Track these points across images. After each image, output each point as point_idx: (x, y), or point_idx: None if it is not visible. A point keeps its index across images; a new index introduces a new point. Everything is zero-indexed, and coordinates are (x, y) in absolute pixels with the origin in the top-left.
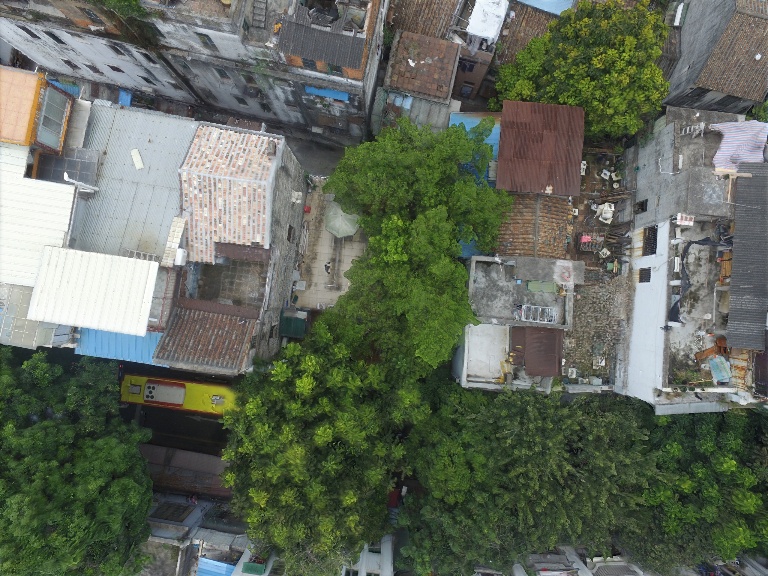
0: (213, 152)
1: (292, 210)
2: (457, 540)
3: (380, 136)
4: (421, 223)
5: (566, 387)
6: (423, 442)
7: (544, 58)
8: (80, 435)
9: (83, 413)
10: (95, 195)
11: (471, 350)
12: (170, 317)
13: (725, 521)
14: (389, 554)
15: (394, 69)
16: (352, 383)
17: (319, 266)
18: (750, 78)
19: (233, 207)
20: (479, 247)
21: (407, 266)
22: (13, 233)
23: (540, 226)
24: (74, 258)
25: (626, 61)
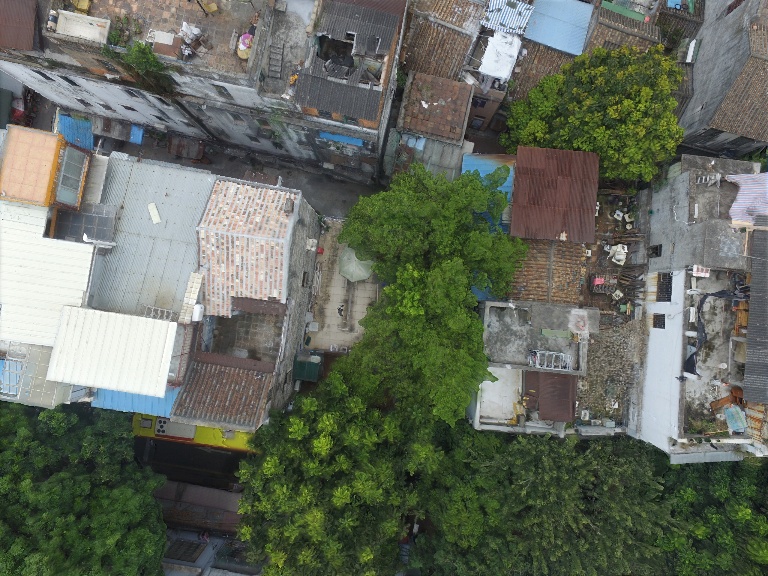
0: (230, 208)
1: (306, 256)
2: None
3: (394, 181)
4: (437, 276)
5: (579, 429)
6: (435, 483)
7: (558, 101)
8: (95, 484)
9: (98, 461)
10: (112, 250)
11: (484, 391)
12: (187, 372)
13: (740, 571)
14: None
15: (407, 111)
16: (369, 439)
17: (332, 307)
18: (764, 121)
19: (250, 263)
20: (493, 293)
21: (423, 318)
22: (32, 293)
23: (554, 271)
24: (93, 318)
25: (642, 112)
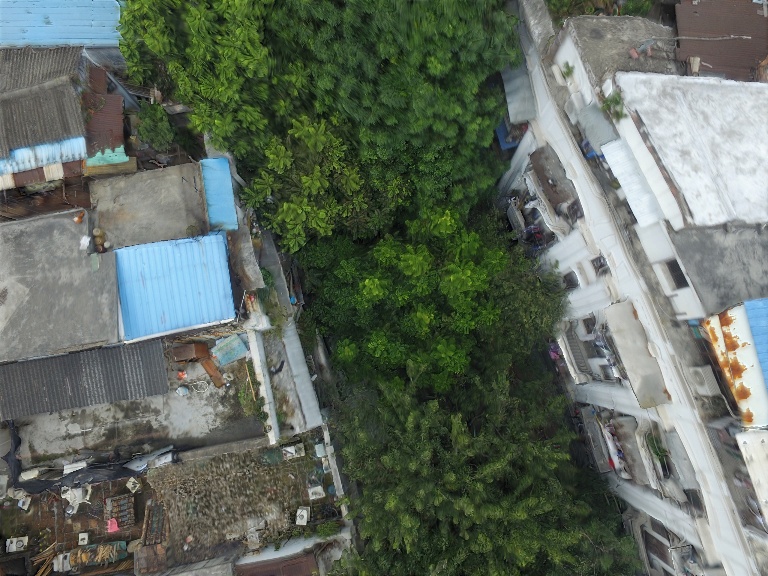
0: None
1: None
2: None
3: None
4: None
5: None
6: None
7: None
8: None
9: None
10: None
11: None
12: None
13: None
14: None
15: None
16: None
17: None
18: None
19: None
20: None
21: None
22: None
23: None
24: None
25: None
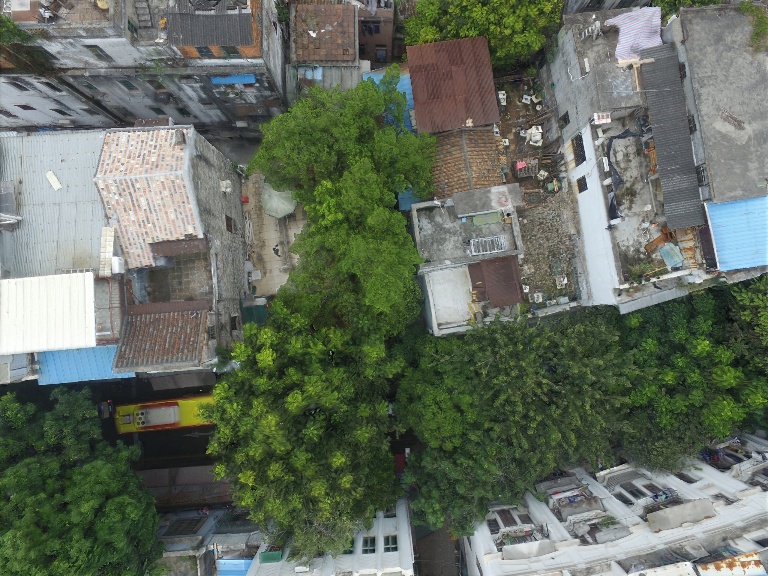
0: (125, 155)
1: (225, 200)
2: (461, 482)
3: None
4: (347, 179)
5: (535, 312)
6: (412, 399)
7: None
8: (66, 466)
9: (65, 445)
10: (19, 225)
11: (437, 299)
12: (122, 326)
13: (710, 400)
14: (404, 515)
15: (297, 44)
16: (314, 348)
17: (269, 252)
18: None
19: (157, 204)
20: (416, 194)
21: (345, 225)
22: None
23: (471, 161)
24: (8, 287)
25: None
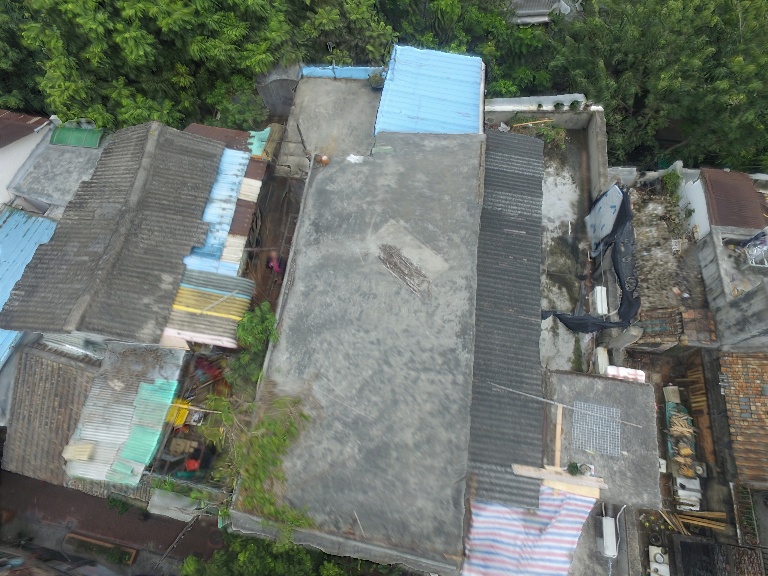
0: None
1: None
2: None
3: None
4: None
5: (639, 177)
6: None
7: None
8: None
9: None
10: None
11: None
12: None
13: None
14: None
15: None
16: None
17: None
18: None
19: None
20: None
21: None
22: None
23: None
24: None
25: None
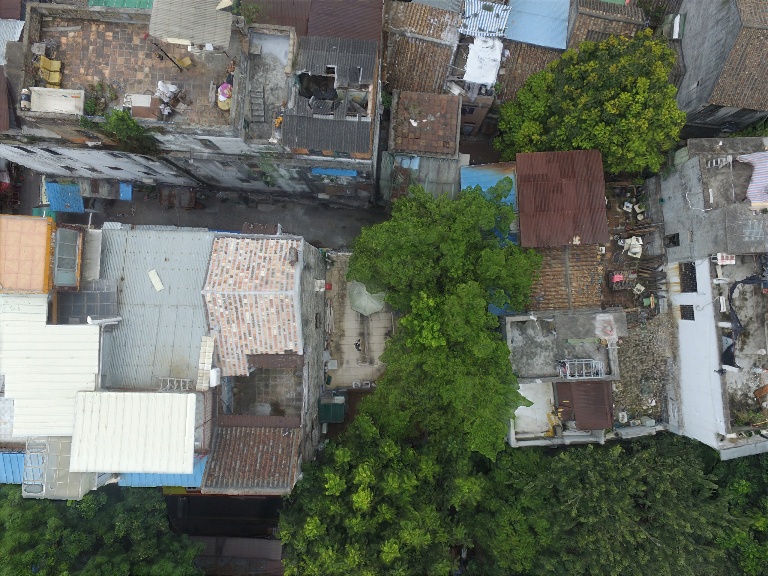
0: (233, 266)
1: (316, 297)
2: None
3: (394, 207)
4: (454, 304)
5: (619, 433)
6: (479, 506)
7: (550, 101)
8: (134, 562)
9: (134, 538)
10: (119, 325)
11: None
12: (212, 439)
13: None
14: None
15: (397, 132)
16: (408, 483)
17: (348, 342)
18: (765, 90)
19: (261, 319)
20: (512, 307)
21: (445, 347)
22: (43, 383)
23: (571, 276)
24: (109, 401)
25: (641, 103)
